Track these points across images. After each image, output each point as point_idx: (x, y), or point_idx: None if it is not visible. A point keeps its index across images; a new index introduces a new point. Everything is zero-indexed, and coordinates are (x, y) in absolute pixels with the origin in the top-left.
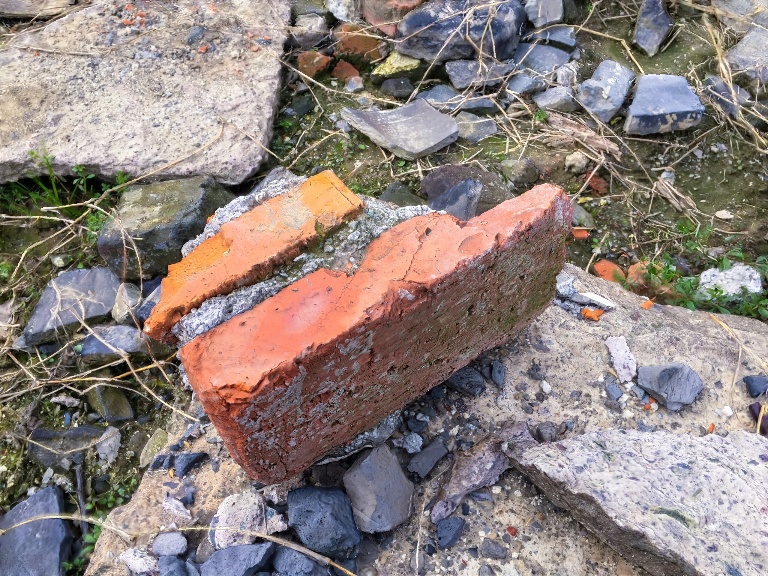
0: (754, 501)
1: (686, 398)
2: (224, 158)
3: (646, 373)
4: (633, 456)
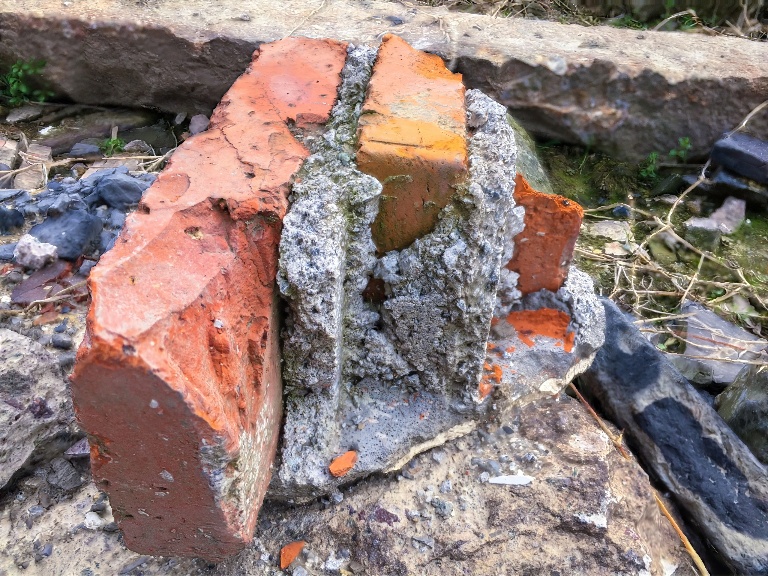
0: None
1: None
2: None
3: None
4: None
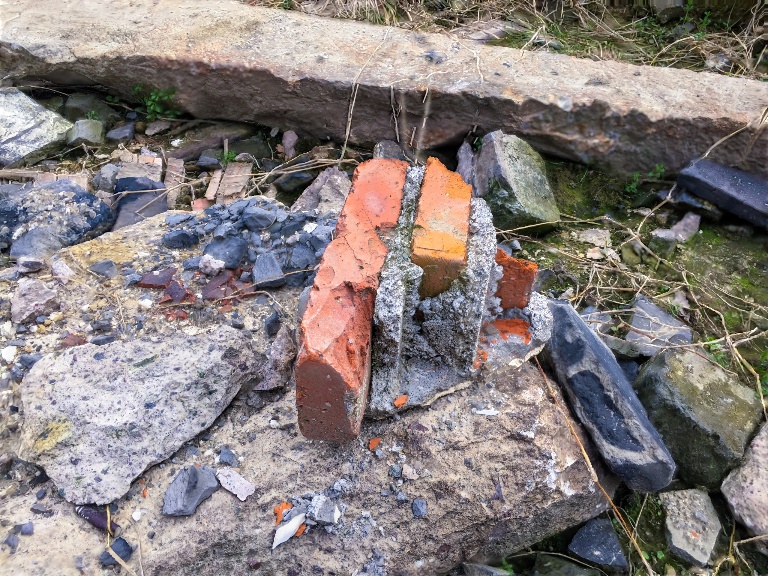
0: (98, 419)
1: (172, 488)
2: (759, 484)
3: (210, 480)
4: (185, 386)
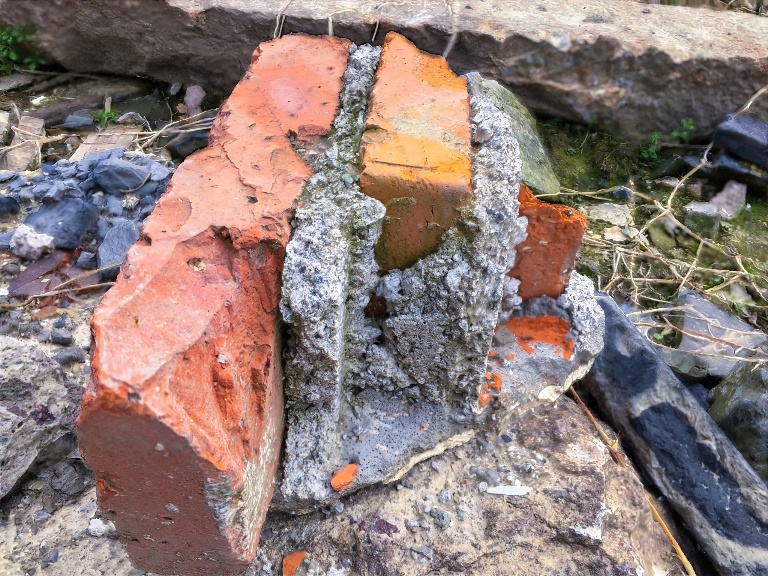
0: None
1: None
2: None
3: None
4: None
